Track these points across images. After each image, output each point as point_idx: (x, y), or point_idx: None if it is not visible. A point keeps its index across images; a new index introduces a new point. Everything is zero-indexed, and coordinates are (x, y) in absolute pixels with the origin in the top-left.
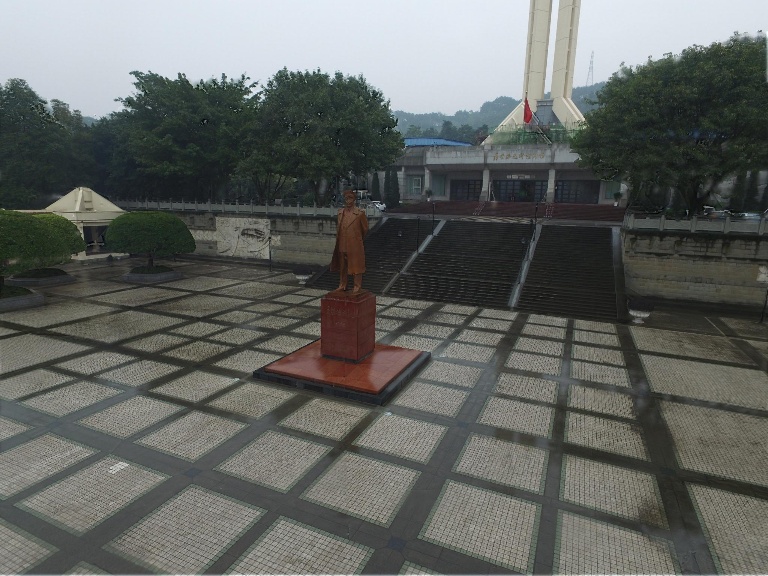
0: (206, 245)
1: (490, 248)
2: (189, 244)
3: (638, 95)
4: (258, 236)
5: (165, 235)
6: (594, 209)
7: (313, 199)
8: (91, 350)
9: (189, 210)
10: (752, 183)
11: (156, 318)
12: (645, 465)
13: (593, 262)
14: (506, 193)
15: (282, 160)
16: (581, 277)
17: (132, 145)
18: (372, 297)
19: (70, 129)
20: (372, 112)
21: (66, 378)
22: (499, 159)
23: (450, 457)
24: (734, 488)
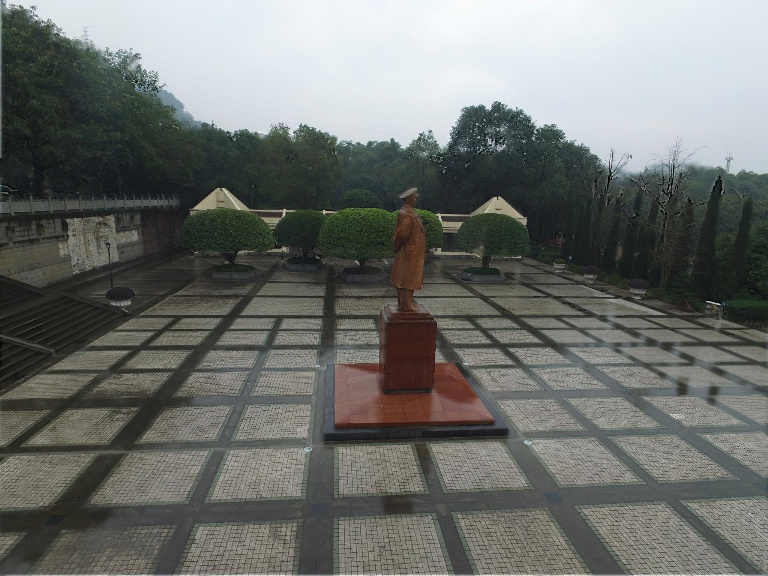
0: None
1: None
2: None
3: None
4: None
5: None
6: None
7: None
8: None
9: None
10: None
11: None
12: None
13: None
14: None
15: None
16: None
17: None
18: None
19: None
20: None
21: None
22: None
23: None
24: None
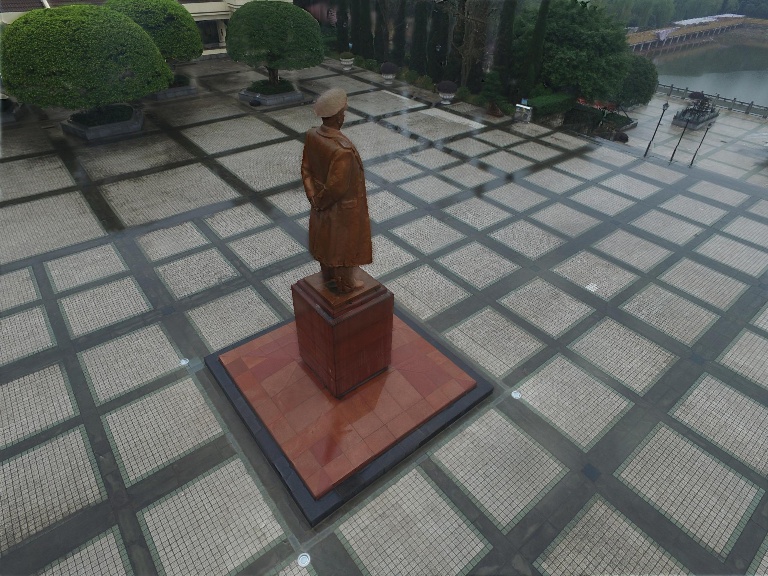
0: None
1: None
2: None
3: None
4: None
5: None
6: None
7: None
8: None
9: None
10: None
11: None
12: None
13: None
14: None
15: None
16: None
17: None
18: None
19: None
20: None
21: None
22: None
23: None
24: (241, 185)
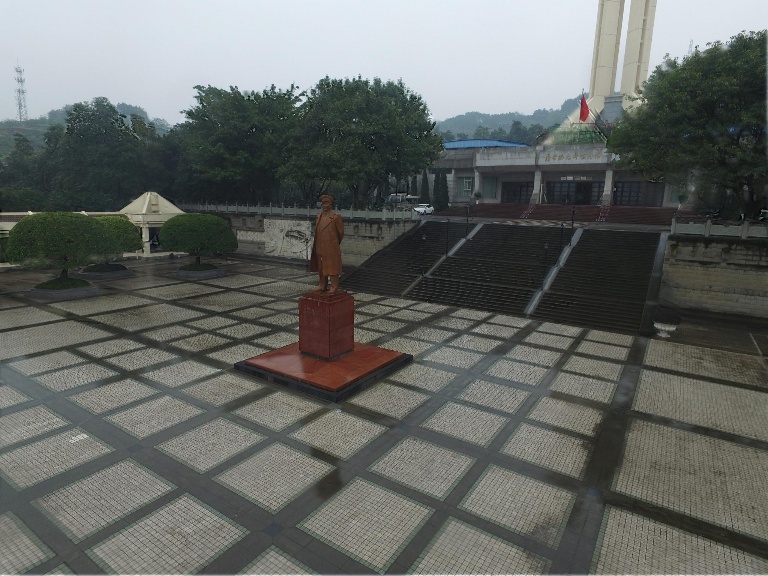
0: (255, 245)
1: (522, 253)
2: (231, 244)
3: (673, 89)
4: (300, 237)
5: (208, 236)
6: (654, 212)
7: (352, 202)
8: (113, 337)
9: (242, 212)
10: None
11: (182, 311)
12: (573, 483)
13: (630, 269)
14: (560, 195)
15: (320, 165)
16: (612, 285)
17: (190, 153)
18: (349, 298)
19: (145, 140)
20: (404, 116)
21: (80, 360)
22: (551, 160)
23: (373, 456)
24: (660, 517)
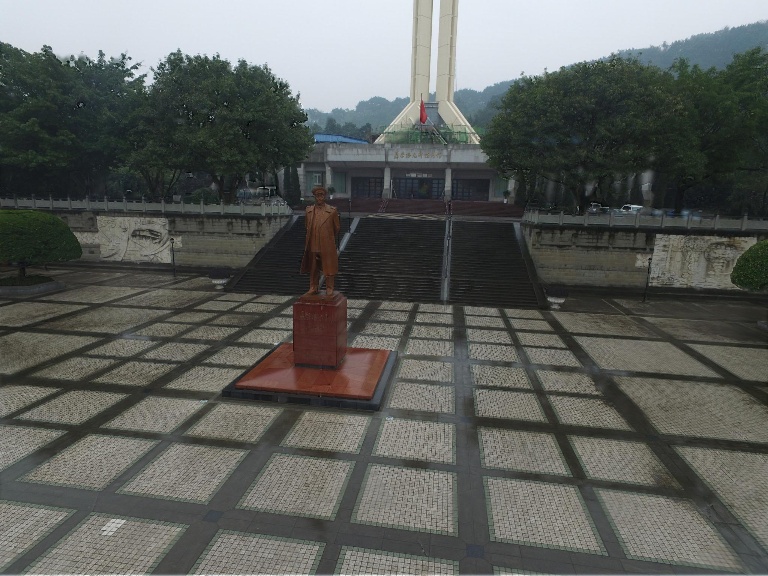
0: (85, 249)
1: (409, 244)
2: (75, 248)
3: (544, 102)
4: (153, 237)
5: (44, 239)
6: (488, 206)
7: (217, 196)
8: None
9: (60, 208)
10: (635, 183)
11: (59, 339)
12: (634, 435)
13: (505, 255)
14: (406, 191)
15: (183, 152)
16: (498, 269)
17: None
18: (344, 299)
19: None
20: (286, 105)
21: None
22: (399, 157)
23: (473, 454)
24: (706, 444)
